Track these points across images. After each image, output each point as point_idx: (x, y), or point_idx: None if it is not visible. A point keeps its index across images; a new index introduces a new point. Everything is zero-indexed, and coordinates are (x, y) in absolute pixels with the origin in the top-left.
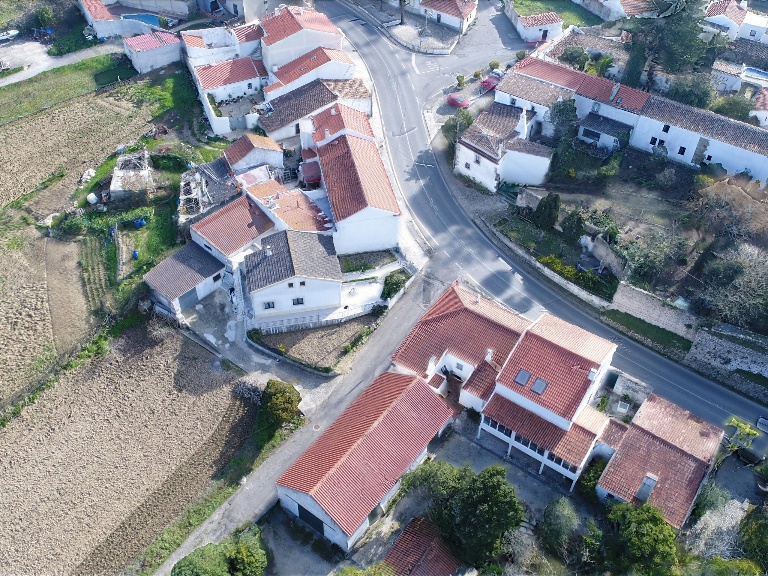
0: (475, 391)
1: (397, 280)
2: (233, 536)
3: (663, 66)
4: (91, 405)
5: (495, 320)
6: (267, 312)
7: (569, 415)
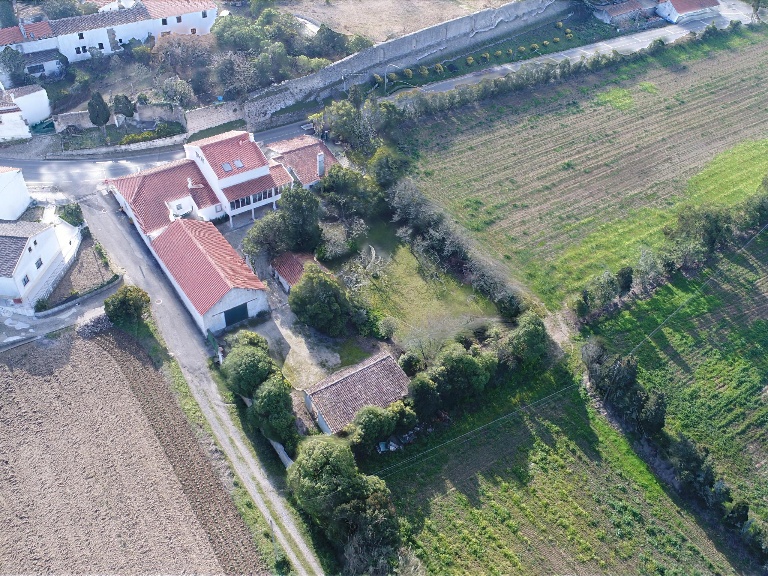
0: (207, 205)
1: (75, 206)
2: (213, 370)
3: (27, 3)
4: (7, 444)
5: (167, 168)
6: (27, 289)
7: (266, 162)
